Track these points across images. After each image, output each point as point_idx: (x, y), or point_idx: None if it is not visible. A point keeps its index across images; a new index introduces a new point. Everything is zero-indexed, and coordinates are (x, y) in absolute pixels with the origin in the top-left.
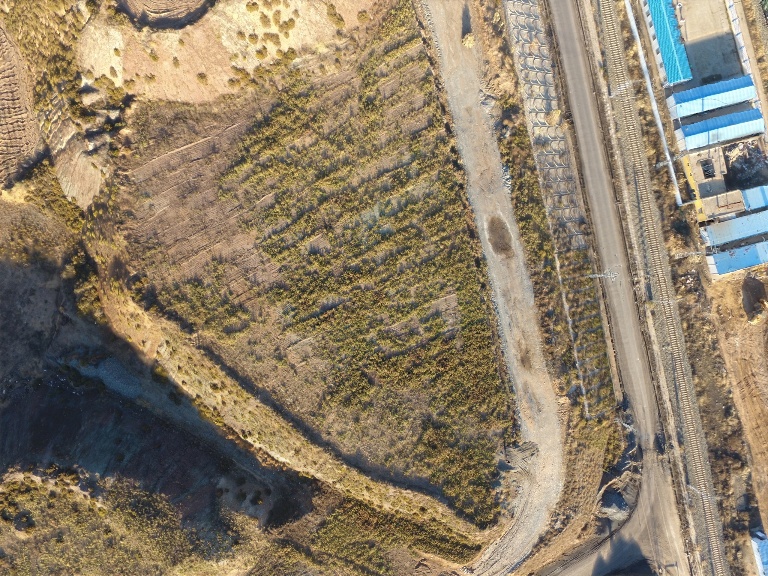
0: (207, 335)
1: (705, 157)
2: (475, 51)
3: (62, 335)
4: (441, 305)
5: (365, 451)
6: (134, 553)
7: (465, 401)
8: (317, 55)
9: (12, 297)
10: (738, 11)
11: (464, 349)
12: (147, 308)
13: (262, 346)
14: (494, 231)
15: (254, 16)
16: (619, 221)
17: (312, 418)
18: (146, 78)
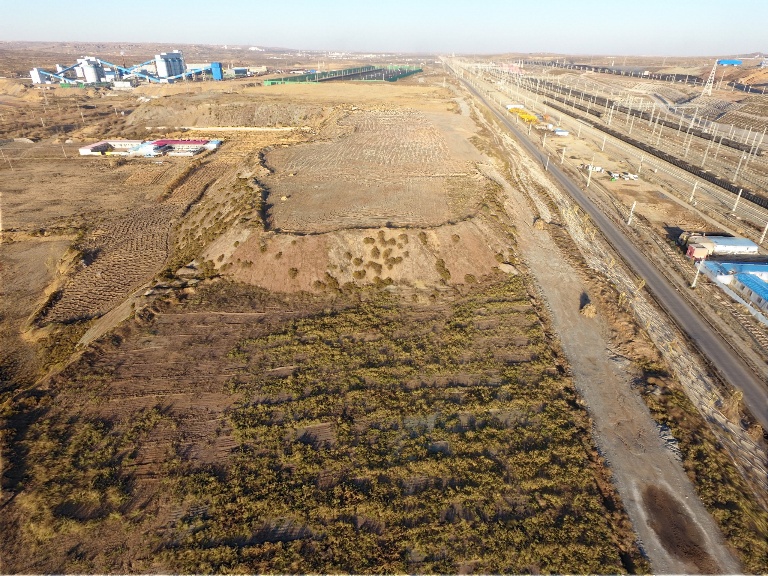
0: (25, 504)
1: None
2: (597, 321)
3: None
4: None
5: None
6: None
7: None
8: (413, 288)
9: None
10: None
11: None
12: (1, 429)
13: (87, 569)
14: (658, 511)
15: (367, 248)
16: None
17: None
18: (244, 263)
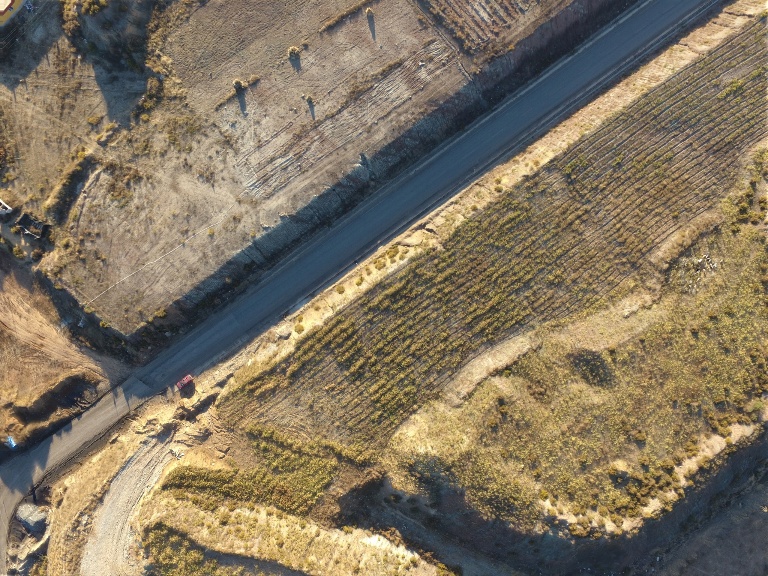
0: None
1: None
2: None
3: None
4: None
5: None
6: (510, 456)
7: None
8: None
9: None
10: None
11: None
12: None
13: None
14: None
15: None
16: None
17: None
18: None
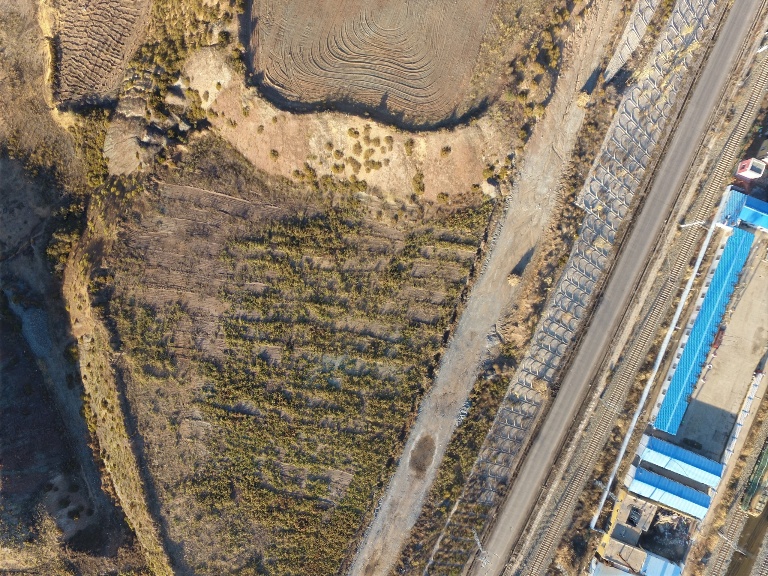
0: (128, 360)
1: (639, 506)
2: (513, 291)
3: (17, 262)
4: (335, 475)
5: (187, 547)
6: None
7: (297, 567)
8: (383, 201)
9: (1, 198)
10: (754, 405)
11: (327, 525)
12: (94, 304)
13: (166, 402)
14: (421, 447)
15: (351, 140)
16: (534, 502)
17: (163, 490)
18: (229, 121)
